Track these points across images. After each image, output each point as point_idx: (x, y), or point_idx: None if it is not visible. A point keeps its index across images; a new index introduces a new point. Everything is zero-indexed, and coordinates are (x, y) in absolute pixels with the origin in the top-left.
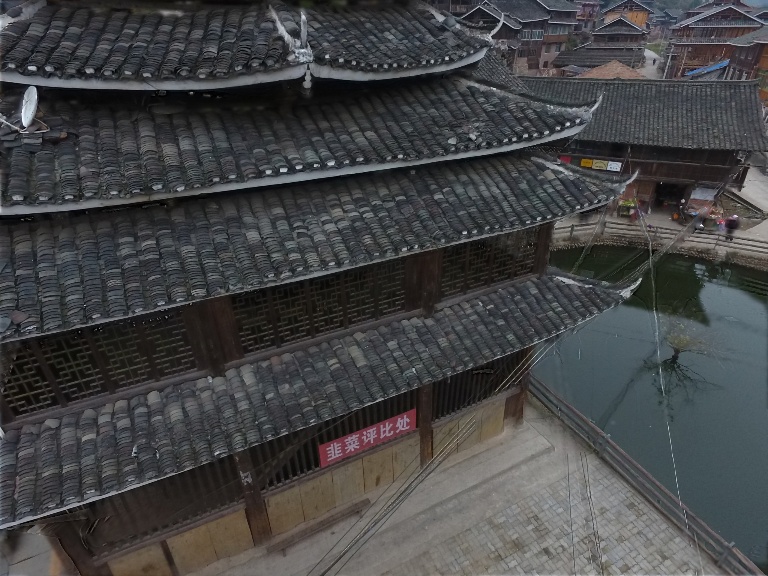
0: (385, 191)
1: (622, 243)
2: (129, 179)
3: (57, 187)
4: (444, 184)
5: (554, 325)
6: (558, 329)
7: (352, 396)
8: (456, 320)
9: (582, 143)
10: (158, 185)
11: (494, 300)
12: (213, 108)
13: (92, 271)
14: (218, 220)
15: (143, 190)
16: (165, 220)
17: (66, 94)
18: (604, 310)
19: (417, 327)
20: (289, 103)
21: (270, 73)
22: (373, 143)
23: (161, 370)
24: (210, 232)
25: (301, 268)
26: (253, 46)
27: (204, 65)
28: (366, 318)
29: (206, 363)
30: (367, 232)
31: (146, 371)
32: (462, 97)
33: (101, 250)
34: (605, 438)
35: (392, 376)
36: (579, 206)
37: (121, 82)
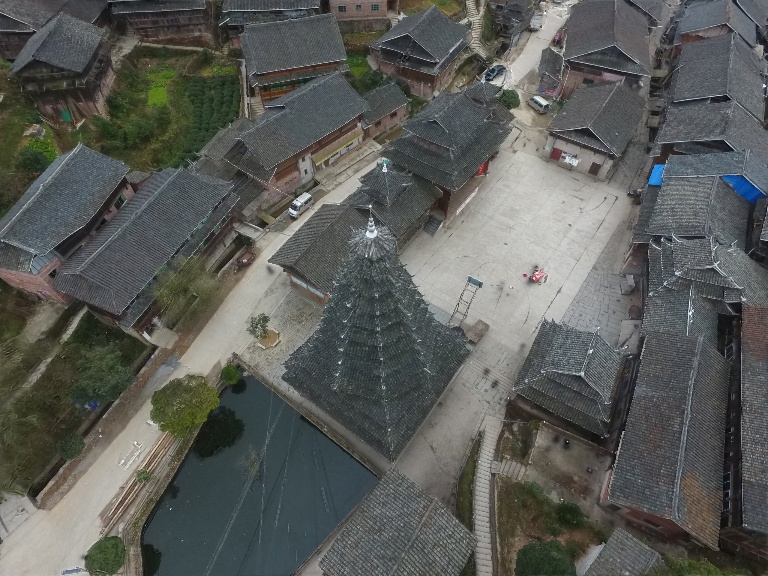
0: None
1: None
2: None
3: None
4: None
5: None
6: None
7: None
8: None
9: None
10: None
11: None
12: None
13: None
14: None
15: None
16: None
17: None
18: None
19: None
20: None
21: None
22: None
23: None
24: None
25: None
26: None
27: None
28: None
29: None
30: None
31: None
32: None
33: None
34: None
35: None
36: None
37: None
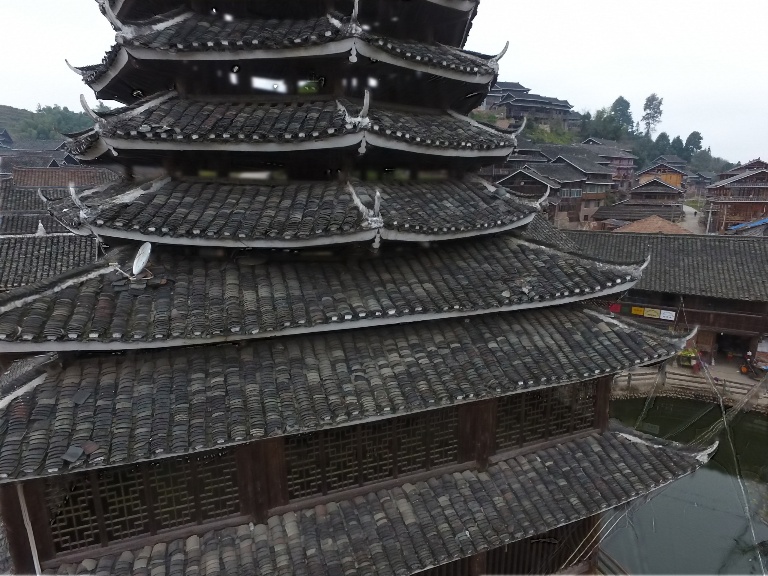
0: (440, 338)
1: (687, 396)
2: (212, 321)
3: (150, 326)
4: (498, 333)
5: (623, 490)
6: (628, 495)
7: (399, 560)
8: (513, 476)
9: (631, 291)
10: (236, 328)
11: (553, 456)
12: (290, 260)
13: (163, 405)
14: (282, 360)
15: (222, 332)
16: (235, 358)
17: (171, 247)
18: (679, 476)
19: (470, 482)
20: (356, 257)
21: (345, 235)
22: (431, 294)
23: (205, 512)
24: (274, 371)
25: (357, 412)
26: (332, 214)
27: (290, 228)
28: (416, 468)
29: (250, 507)
30: (422, 378)
31: (190, 512)
32: (513, 254)
33: (174, 385)
34: None
35: (443, 538)
36: (638, 360)
37: (220, 241)
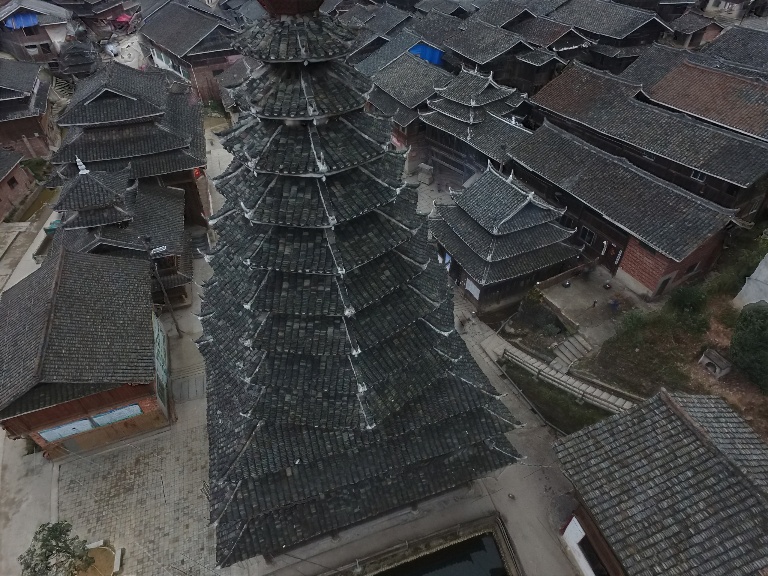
0: None
1: None
2: None
3: None
4: None
5: None
6: None
7: None
8: None
9: None
10: None
11: None
12: None
13: None
14: None
15: None
16: None
17: None
18: None
19: None
20: None
21: None
22: None
23: None
24: None
25: None
26: None
27: None
28: None
29: None
30: None
31: None
32: None
33: None
34: None
35: None
36: None
37: None
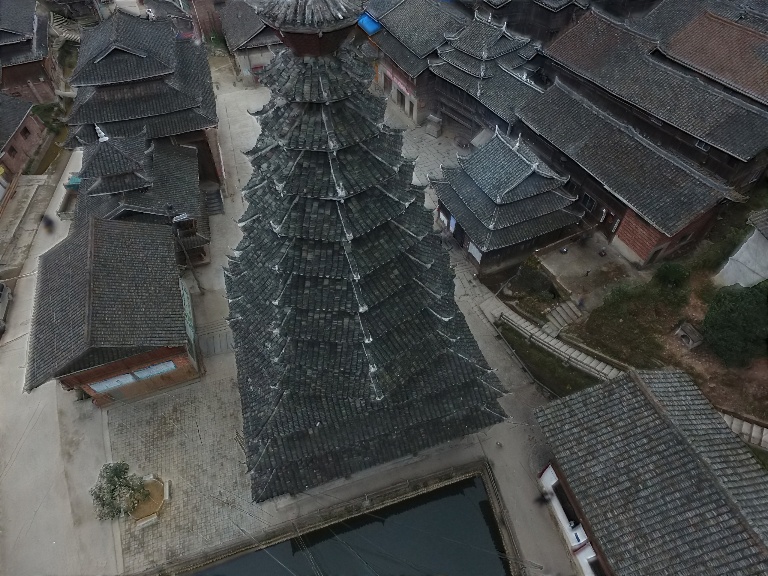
0: None
1: None
2: None
3: None
4: None
5: None
6: None
7: None
8: None
9: None
10: None
11: None
12: None
13: None
14: None
15: None
16: None
17: None
18: None
19: None
20: None
21: None
22: None
23: None
24: None
25: None
26: None
27: None
28: None
29: None
30: None
31: None
32: None
33: None
34: (262, 528)
35: None
36: None
37: None
